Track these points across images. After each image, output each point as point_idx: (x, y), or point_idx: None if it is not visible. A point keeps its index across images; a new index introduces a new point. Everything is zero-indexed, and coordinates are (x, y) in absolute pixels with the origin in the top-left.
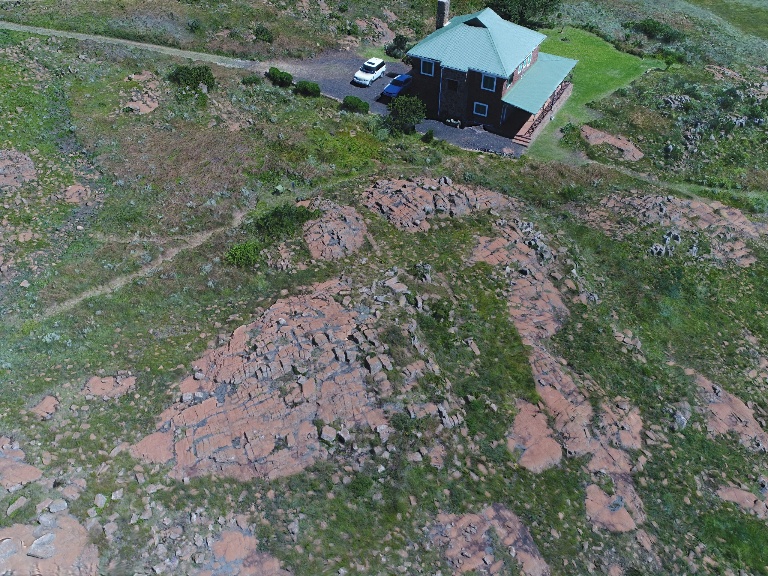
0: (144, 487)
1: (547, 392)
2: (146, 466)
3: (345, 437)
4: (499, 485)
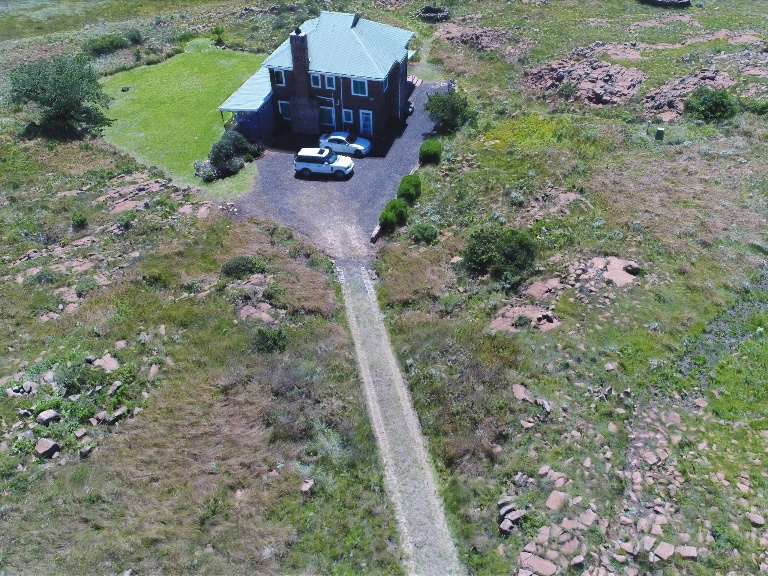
0: None
1: None
2: None
3: None
4: None
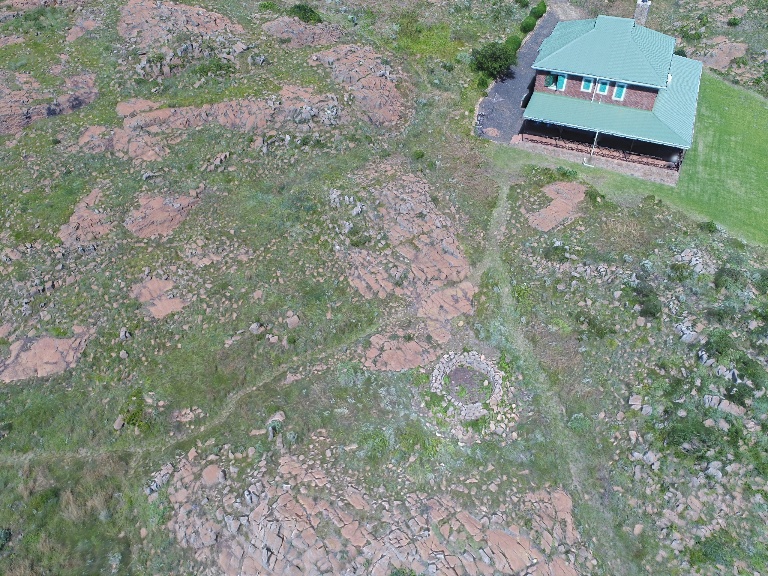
0: (117, 2)
1: (165, 111)
2: (126, 1)
3: (131, 39)
4: (109, 94)
